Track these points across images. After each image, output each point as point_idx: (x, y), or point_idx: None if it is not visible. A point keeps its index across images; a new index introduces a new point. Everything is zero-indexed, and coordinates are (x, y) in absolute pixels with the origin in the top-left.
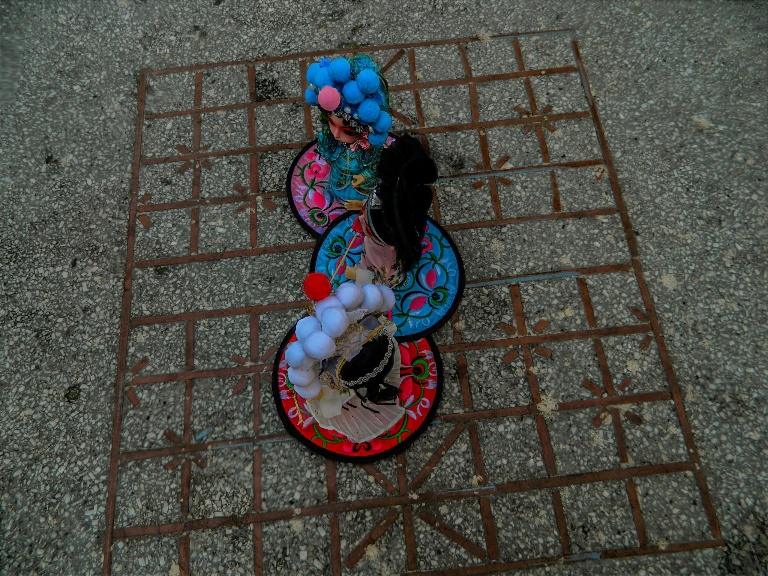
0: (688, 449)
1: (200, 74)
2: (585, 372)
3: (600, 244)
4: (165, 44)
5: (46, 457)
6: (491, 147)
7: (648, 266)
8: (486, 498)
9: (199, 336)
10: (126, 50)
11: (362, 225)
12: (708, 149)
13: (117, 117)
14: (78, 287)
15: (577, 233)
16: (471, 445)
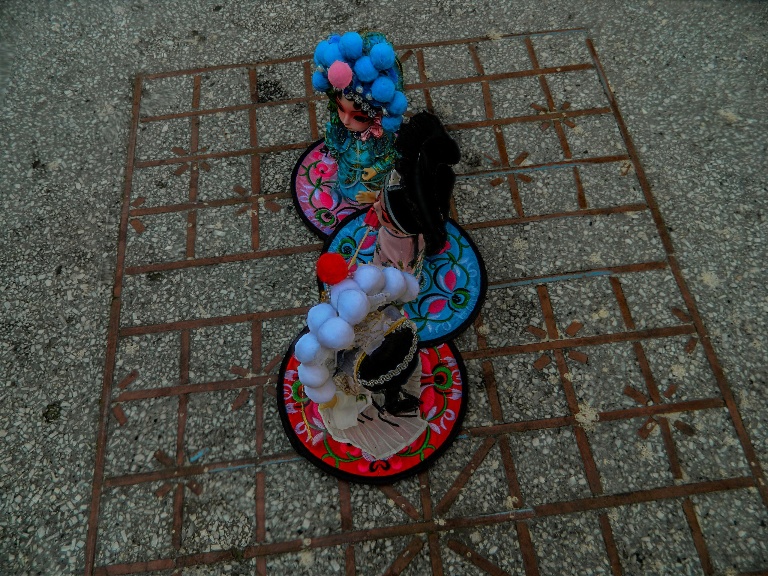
0: (749, 462)
1: (199, 77)
2: (626, 378)
3: (632, 241)
4: (162, 49)
5: (19, 485)
6: (508, 144)
7: (686, 263)
8: (523, 523)
9: (195, 346)
10: (121, 55)
11: (377, 213)
12: (739, 142)
13: (110, 121)
14: (62, 296)
15: (606, 230)
16: (503, 462)
